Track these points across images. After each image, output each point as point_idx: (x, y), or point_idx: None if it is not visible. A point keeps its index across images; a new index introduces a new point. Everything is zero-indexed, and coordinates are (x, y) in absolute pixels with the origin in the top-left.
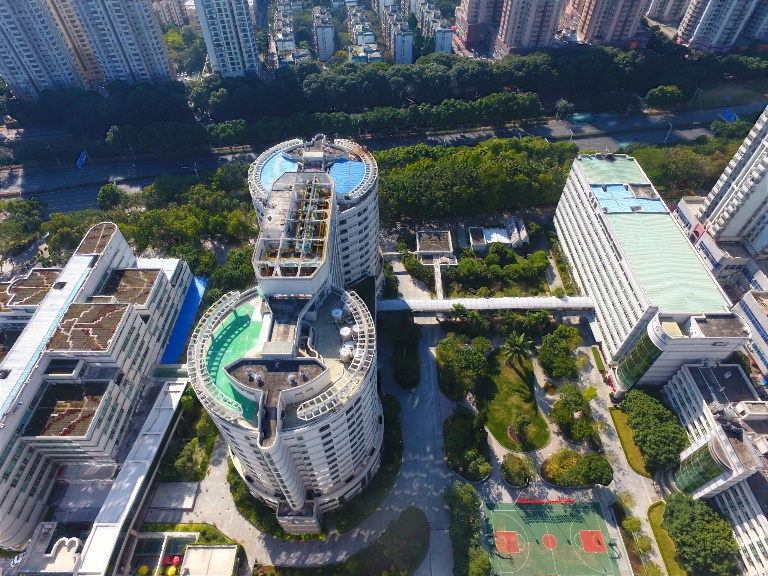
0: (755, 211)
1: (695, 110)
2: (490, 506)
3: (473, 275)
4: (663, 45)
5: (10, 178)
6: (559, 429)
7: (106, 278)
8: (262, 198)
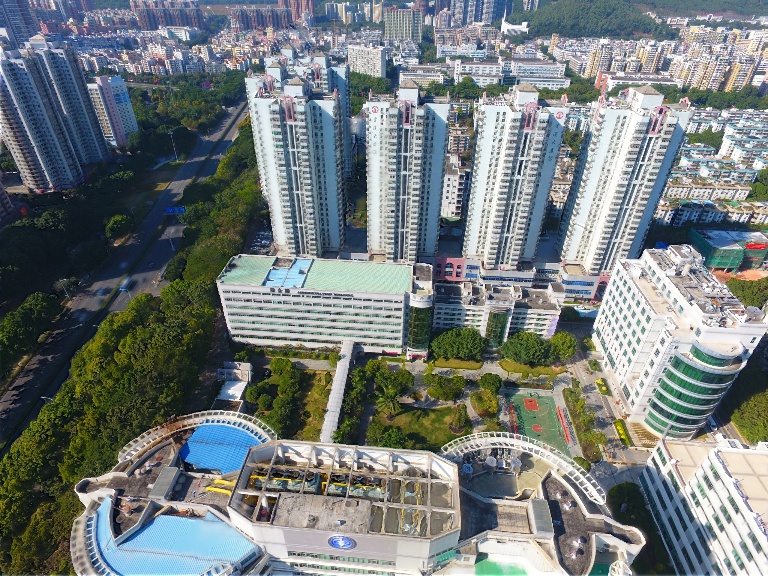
0: (319, 229)
1: (141, 222)
2: None
3: (286, 420)
4: (31, 201)
5: None
6: None
7: None
8: None
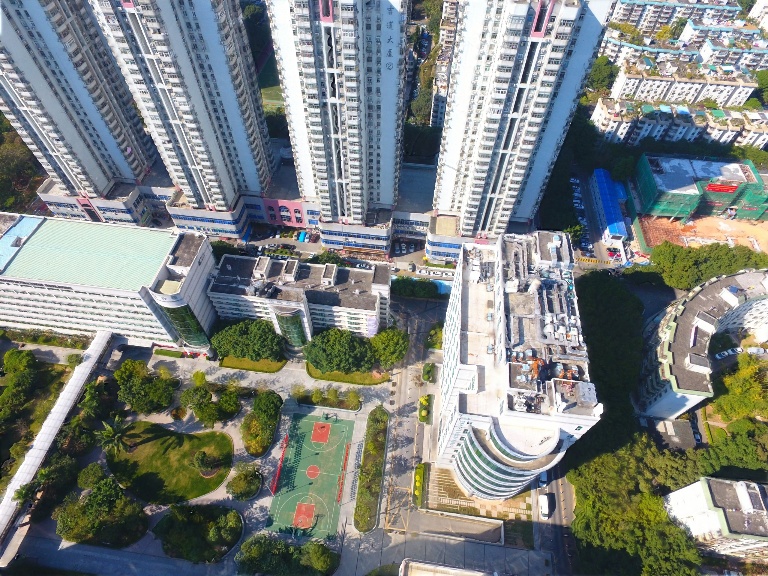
0: (92, 157)
1: None
2: (269, 523)
3: None
4: None
5: None
6: (221, 422)
7: None
8: None
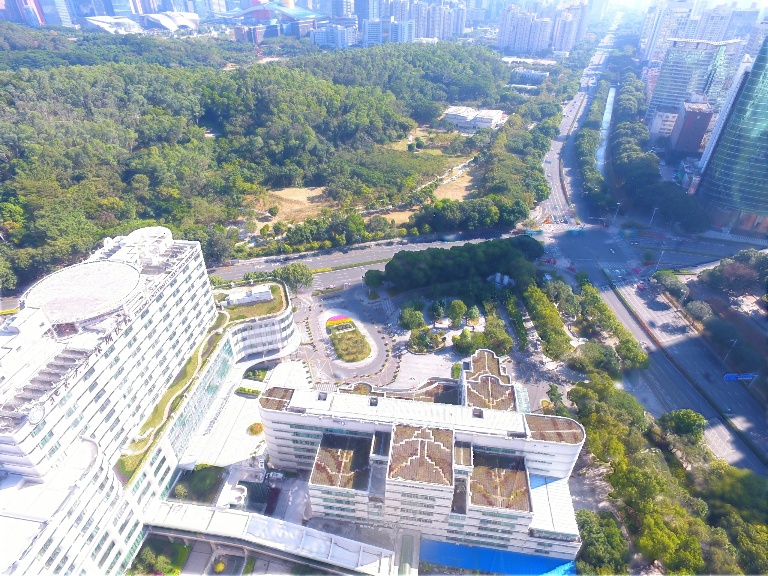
0: None
1: None
2: None
3: None
4: None
5: (678, 328)
6: None
7: (509, 453)
8: None
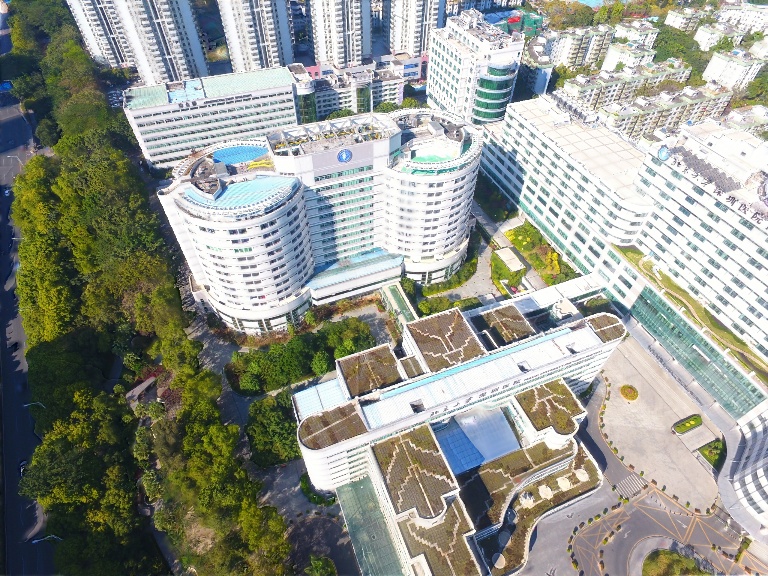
0: None
1: None
2: None
3: None
4: None
5: None
6: None
7: None
8: (285, 197)
